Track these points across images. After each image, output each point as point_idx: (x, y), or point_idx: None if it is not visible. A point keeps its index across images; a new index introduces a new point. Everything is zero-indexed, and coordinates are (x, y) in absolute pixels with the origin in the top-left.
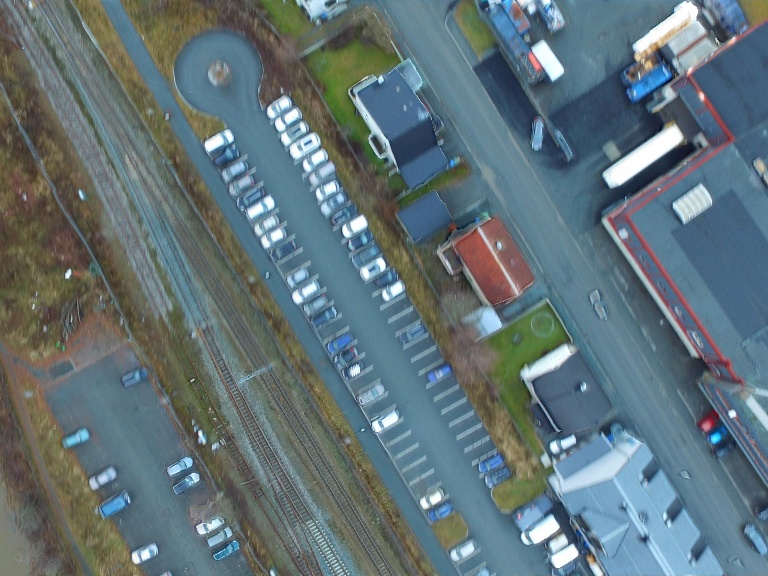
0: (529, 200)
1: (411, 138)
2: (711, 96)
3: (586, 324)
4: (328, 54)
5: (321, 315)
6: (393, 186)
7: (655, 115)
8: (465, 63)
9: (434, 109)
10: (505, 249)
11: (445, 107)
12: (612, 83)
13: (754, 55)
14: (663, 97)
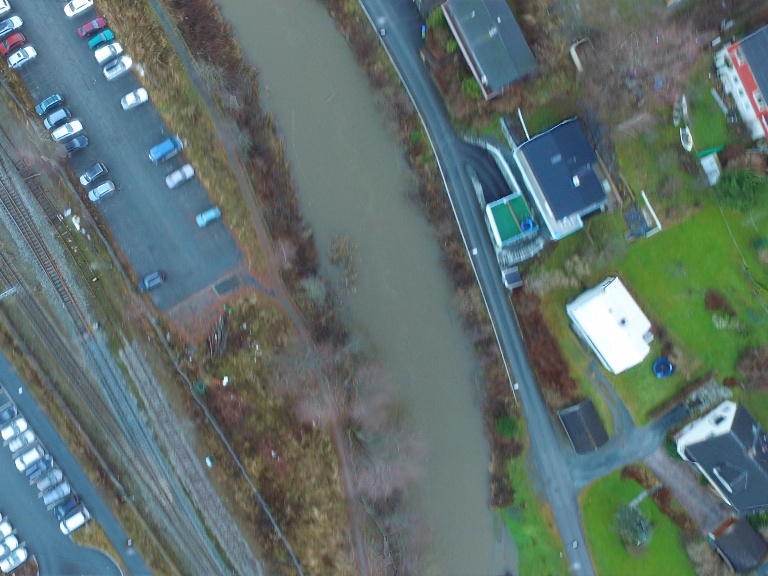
0: None
1: None
2: None
3: None
4: None
5: None
6: None
7: None
8: None
9: None
10: None
11: None
12: None
13: None
14: None
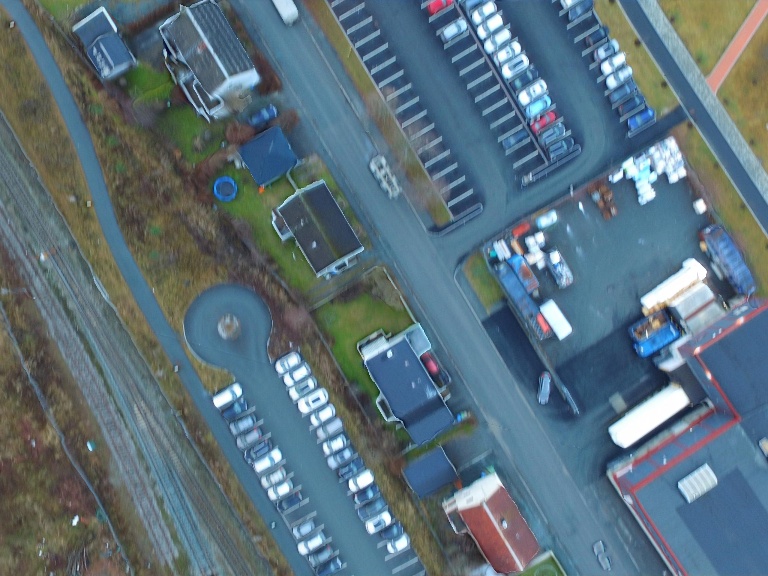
0: (535, 452)
1: (419, 410)
2: (718, 376)
3: (589, 574)
4: (337, 307)
5: (326, 567)
6: (400, 438)
7: (662, 372)
8: (473, 317)
9: (442, 362)
10: (510, 523)
11: (453, 360)
12: (619, 336)
13: (762, 336)
14: (670, 354)
